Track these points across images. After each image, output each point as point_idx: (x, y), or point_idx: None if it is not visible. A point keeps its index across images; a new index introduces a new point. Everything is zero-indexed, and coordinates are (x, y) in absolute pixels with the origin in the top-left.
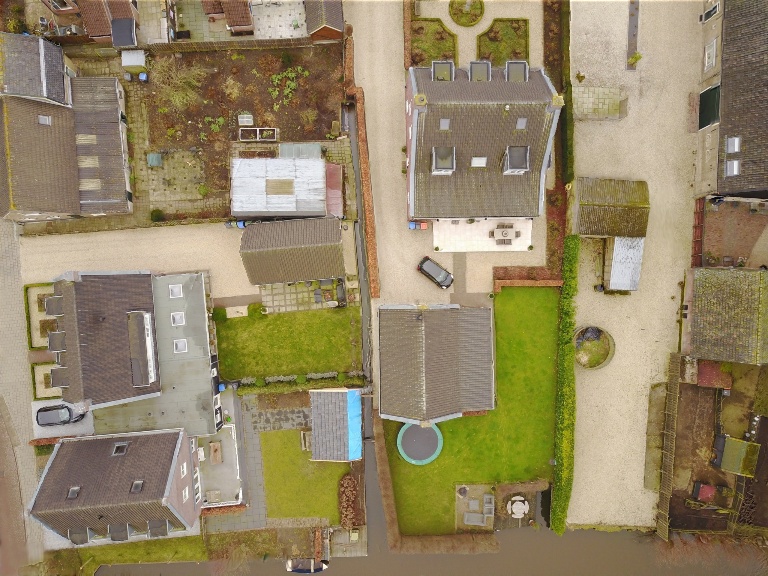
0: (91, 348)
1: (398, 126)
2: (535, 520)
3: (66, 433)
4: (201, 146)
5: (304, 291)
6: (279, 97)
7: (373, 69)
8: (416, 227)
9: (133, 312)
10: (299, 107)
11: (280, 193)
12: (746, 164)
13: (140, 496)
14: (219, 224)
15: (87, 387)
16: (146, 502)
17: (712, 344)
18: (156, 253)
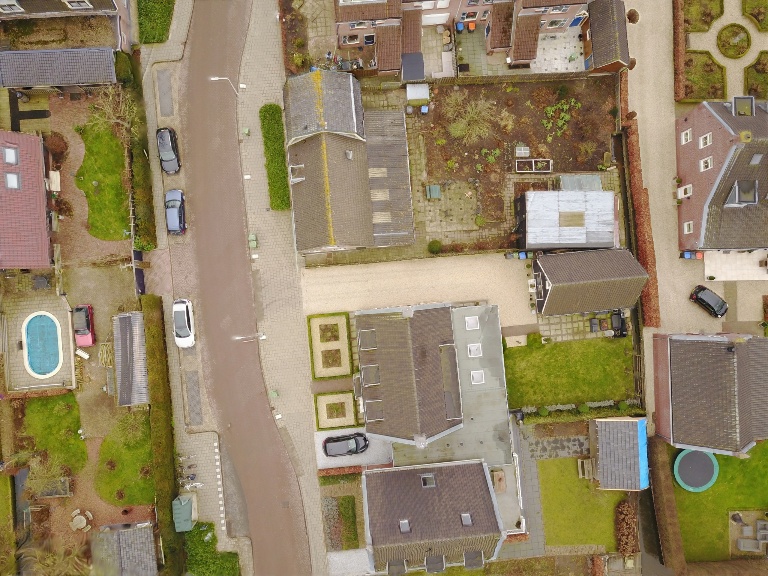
0: (422, 383)
1: (668, 157)
2: None
3: (349, 463)
4: (477, 177)
5: (579, 320)
6: (552, 129)
7: (643, 101)
8: (691, 257)
9: (445, 345)
10: (571, 138)
11: (570, 225)
12: None
13: (476, 530)
14: (495, 254)
15: (421, 422)
16: (482, 535)
17: None
18: (433, 283)
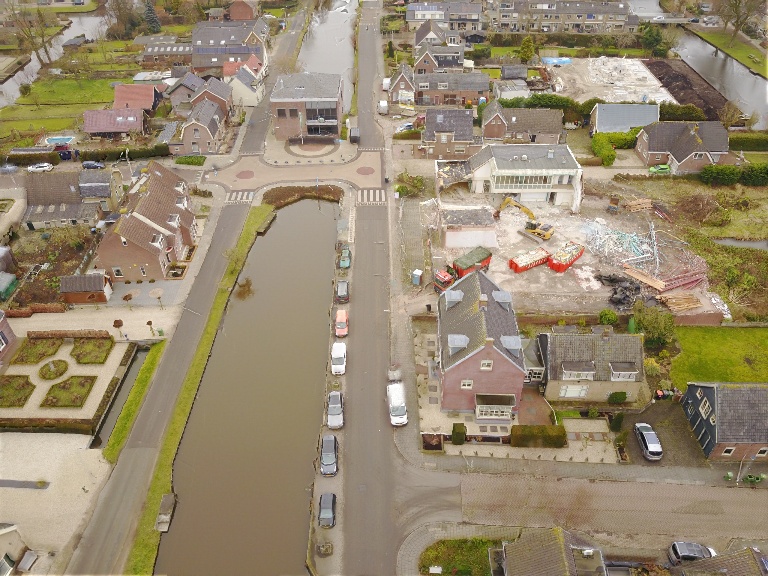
0: None
1: None
2: None
3: None
4: None
5: None
6: None
7: None
8: None
9: None
10: None
11: None
12: None
13: None
14: None
15: None
16: None
17: None
18: None
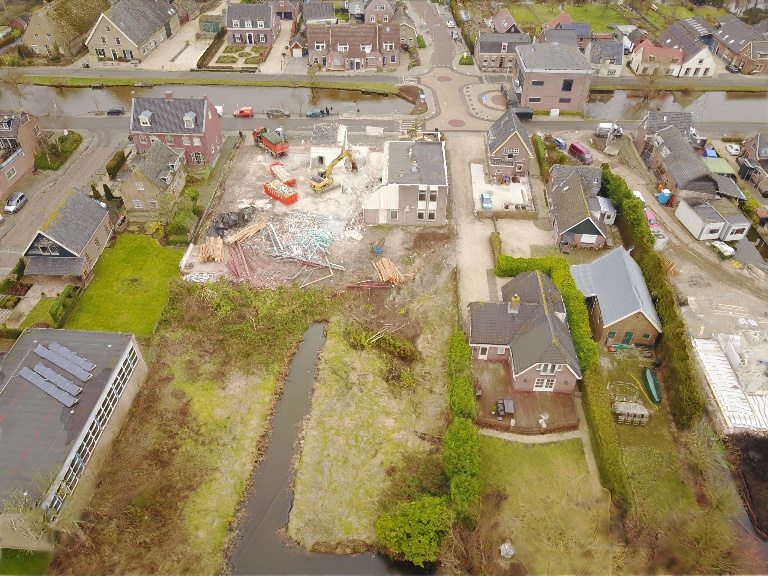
0: None
1: None
2: (259, 0)
3: None
4: None
5: None
6: None
7: None
8: None
9: (368, 0)
10: None
11: None
12: (169, 8)
13: None
14: None
15: None
16: None
17: (193, 3)
18: None
